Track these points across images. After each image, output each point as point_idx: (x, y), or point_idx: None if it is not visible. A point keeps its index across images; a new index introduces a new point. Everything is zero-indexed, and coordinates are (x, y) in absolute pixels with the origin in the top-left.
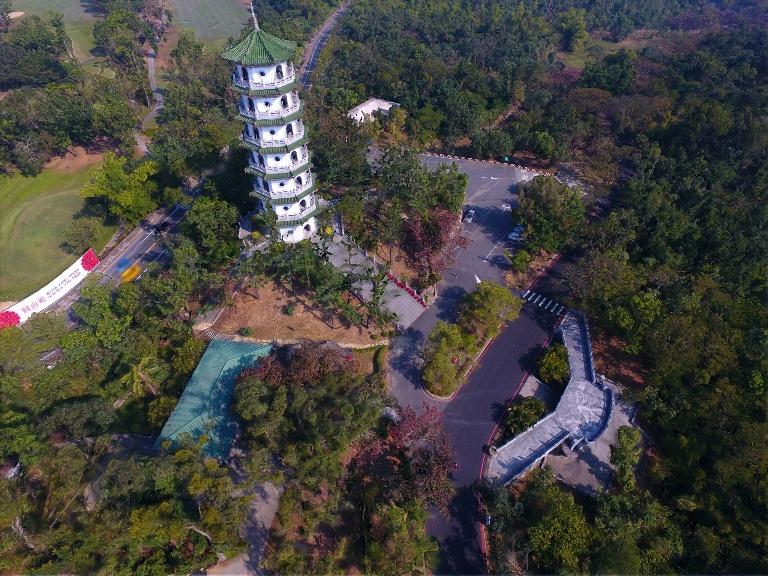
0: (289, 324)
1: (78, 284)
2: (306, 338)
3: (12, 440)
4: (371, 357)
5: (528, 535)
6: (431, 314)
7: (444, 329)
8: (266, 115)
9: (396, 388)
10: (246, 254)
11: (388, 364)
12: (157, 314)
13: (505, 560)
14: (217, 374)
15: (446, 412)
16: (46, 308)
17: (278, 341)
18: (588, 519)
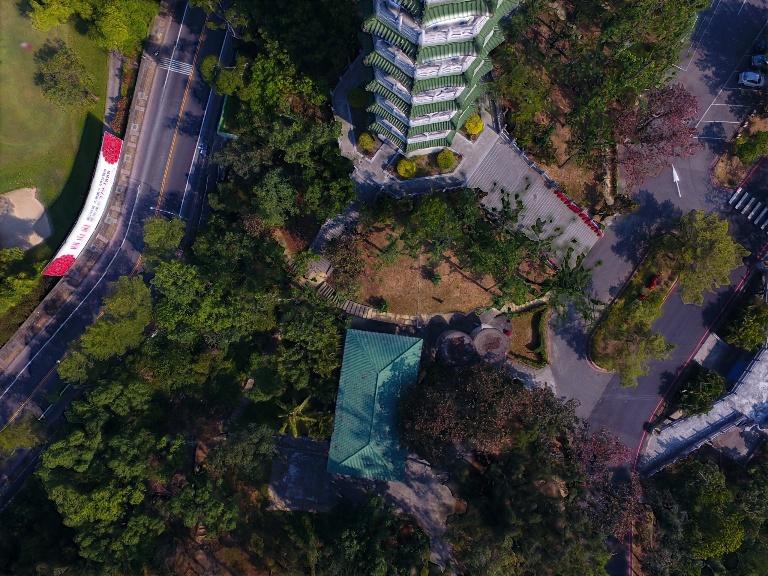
0: (434, 293)
1: (113, 186)
2: (456, 310)
3: (201, 508)
4: (529, 320)
5: (692, 552)
6: (605, 246)
7: (640, 317)
8: (441, 38)
9: (558, 359)
10: (356, 176)
11: (549, 327)
12: (263, 287)
13: (662, 560)
14: (372, 391)
15: (610, 386)
16: (94, 232)
17: (423, 317)
18: (726, 482)
